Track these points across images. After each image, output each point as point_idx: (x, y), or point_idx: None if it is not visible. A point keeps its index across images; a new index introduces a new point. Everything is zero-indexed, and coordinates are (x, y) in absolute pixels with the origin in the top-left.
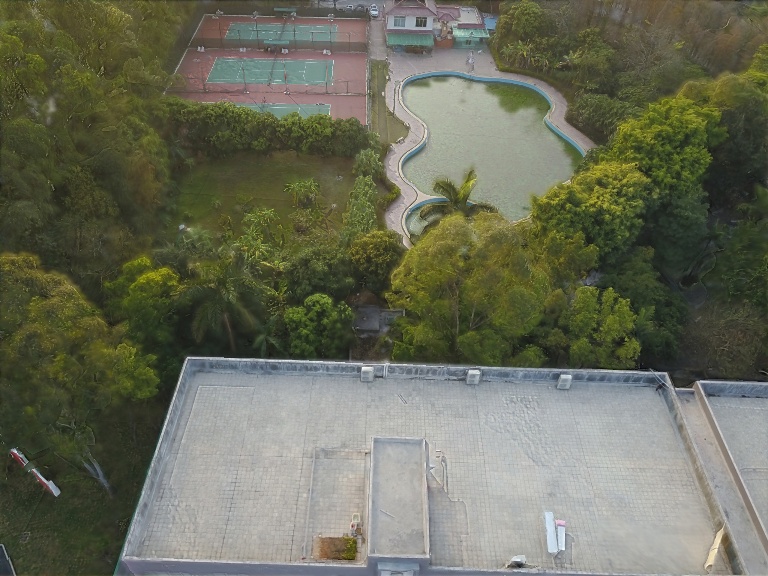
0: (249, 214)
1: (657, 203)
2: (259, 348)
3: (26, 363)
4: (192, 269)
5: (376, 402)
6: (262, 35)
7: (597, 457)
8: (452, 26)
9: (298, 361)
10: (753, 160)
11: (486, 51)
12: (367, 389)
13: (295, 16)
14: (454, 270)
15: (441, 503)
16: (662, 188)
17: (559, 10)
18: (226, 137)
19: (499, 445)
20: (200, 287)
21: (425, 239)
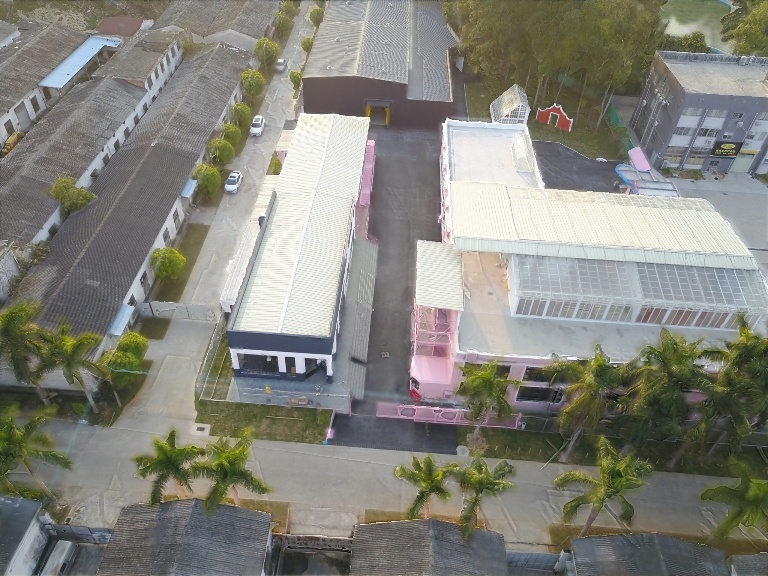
0: None
1: None
2: (641, 83)
3: None
4: None
5: None
6: None
7: None
8: None
9: None
10: None
11: None
12: (743, 67)
13: None
14: None
15: None
16: None
17: None
18: None
19: None
20: None
21: (763, 4)
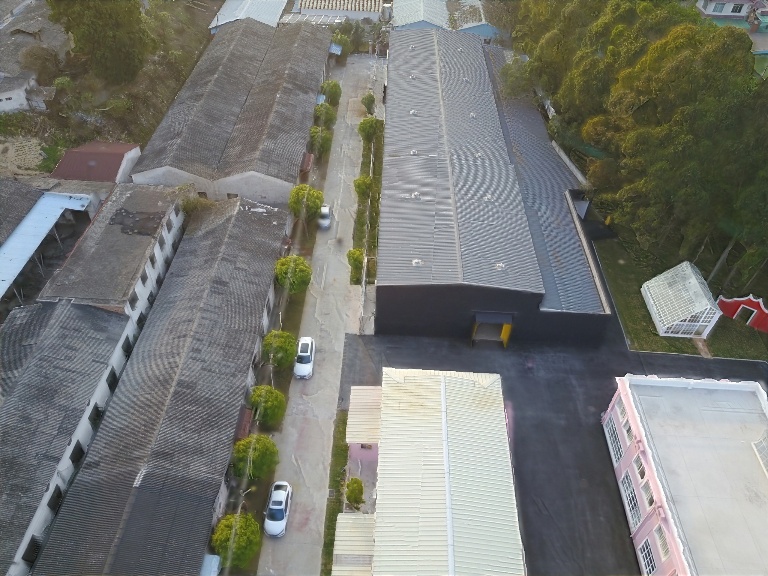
0: None
1: None
2: None
3: None
4: None
5: None
6: None
7: None
8: (756, 13)
9: None
10: None
11: None
12: None
13: None
14: None
15: None
16: None
17: None
18: None
19: None
20: None
21: None
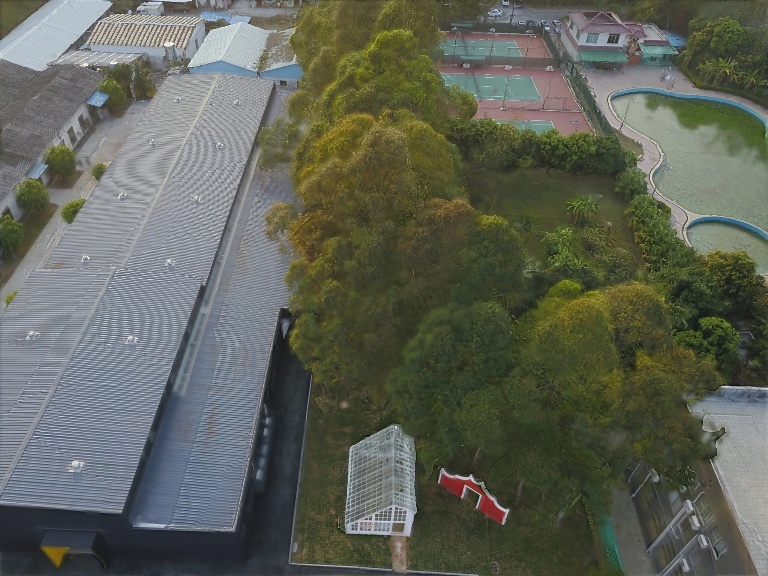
0: (547, 233)
1: None
2: None
3: None
4: None
5: None
6: (447, 50)
7: None
8: (639, 43)
9: None
10: None
11: (673, 68)
12: None
13: (470, 31)
14: None
15: None
16: None
17: (760, 28)
18: (495, 154)
19: None
20: None
21: None
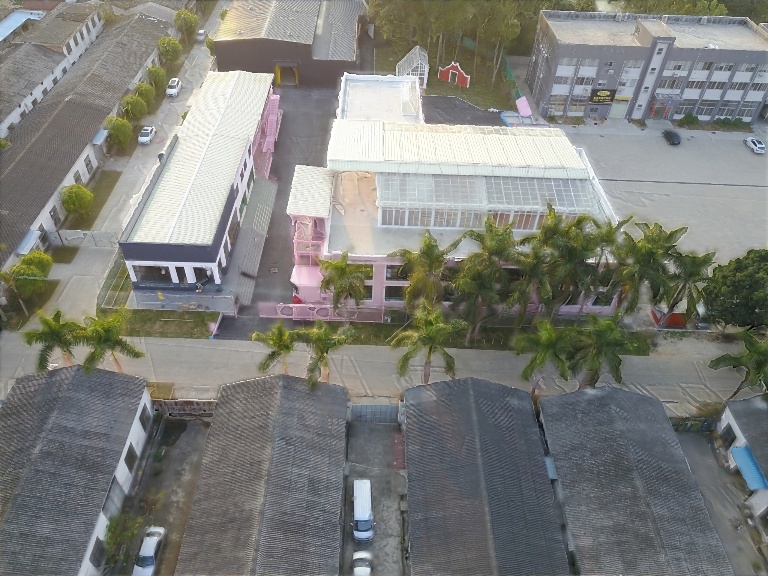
0: None
1: None
2: None
3: None
4: None
5: (625, 26)
6: None
7: None
8: None
9: (589, 12)
10: None
11: None
12: (619, 23)
13: None
14: None
15: None
16: None
17: None
18: None
19: None
20: None
21: None
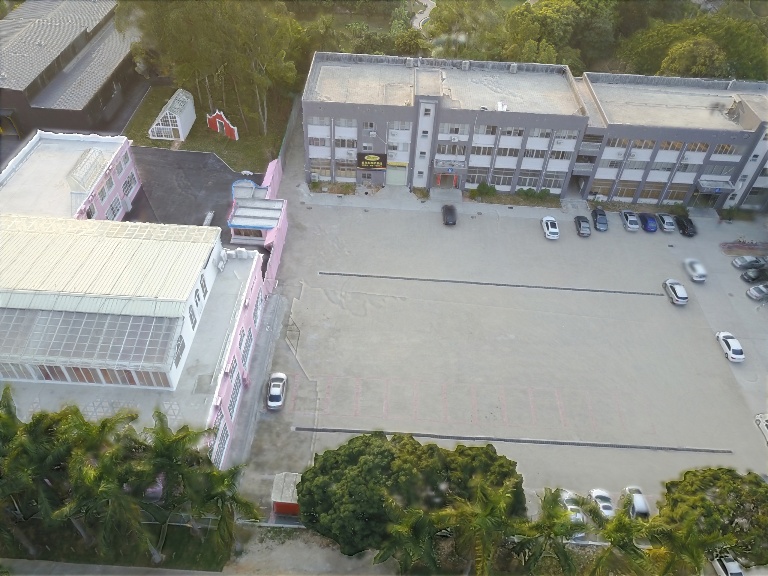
0: None
1: (583, 21)
2: None
3: (263, 6)
4: (308, 27)
5: None
6: None
7: (527, 92)
8: None
9: (373, 55)
10: (648, 4)
11: None
12: (410, 70)
13: None
14: (456, 2)
15: (448, 100)
16: (586, 12)
17: None
18: None
19: (477, 87)
20: (316, 30)
21: None
